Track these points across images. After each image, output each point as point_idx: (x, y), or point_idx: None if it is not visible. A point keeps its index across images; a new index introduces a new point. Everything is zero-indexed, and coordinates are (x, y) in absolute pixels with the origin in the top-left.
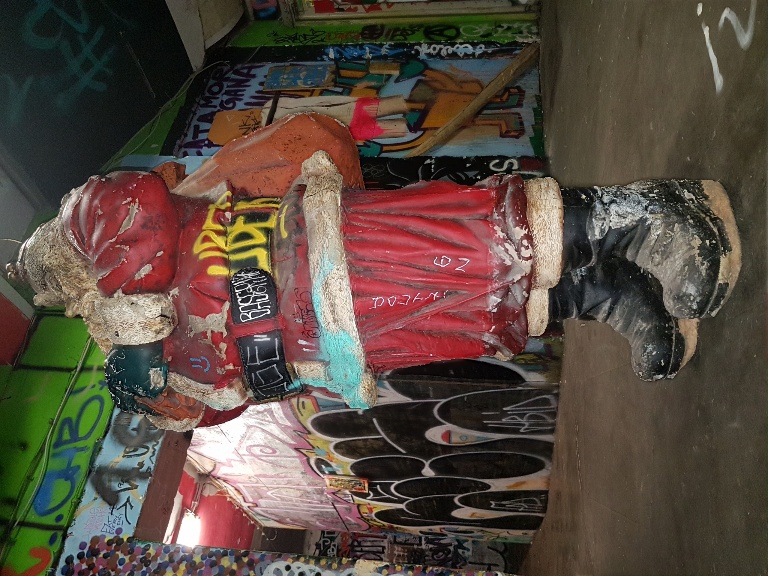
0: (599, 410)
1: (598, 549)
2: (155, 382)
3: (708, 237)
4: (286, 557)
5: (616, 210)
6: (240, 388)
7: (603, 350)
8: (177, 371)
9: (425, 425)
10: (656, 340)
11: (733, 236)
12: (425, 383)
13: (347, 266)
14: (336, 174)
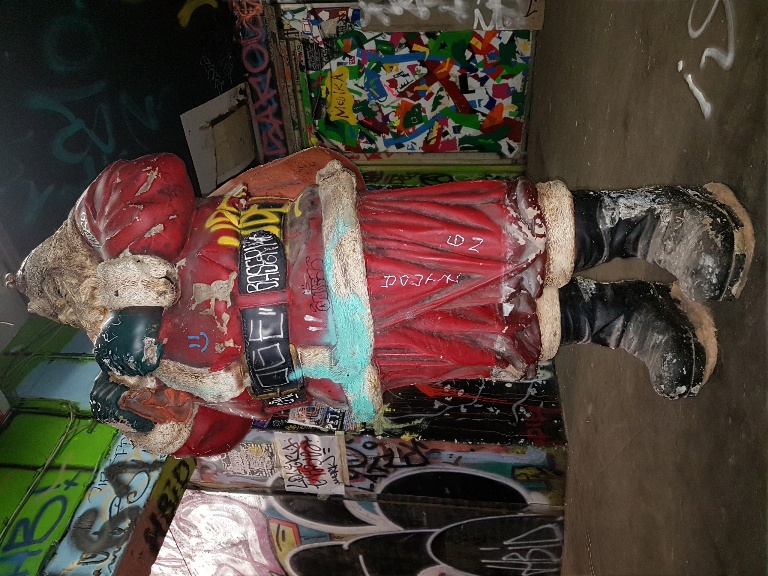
0: (613, 501)
1: None
2: (148, 356)
3: (718, 216)
4: None
5: (624, 203)
6: (237, 374)
7: (613, 432)
8: (171, 357)
9: (417, 565)
10: (675, 348)
11: (743, 215)
12: (419, 506)
13: (361, 237)
14: None
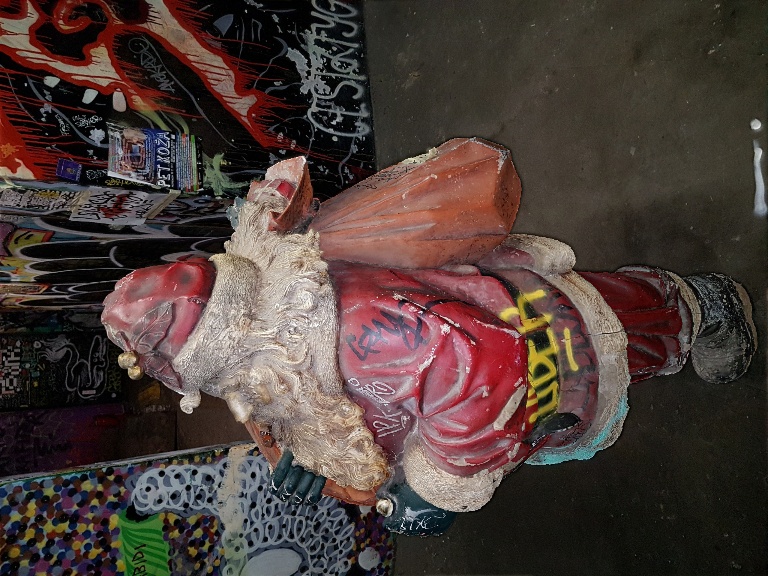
0: None
1: None
2: None
3: None
4: (157, 464)
5: (711, 314)
6: None
7: None
8: None
9: (171, 251)
10: None
11: (756, 341)
12: (211, 228)
13: None
14: None
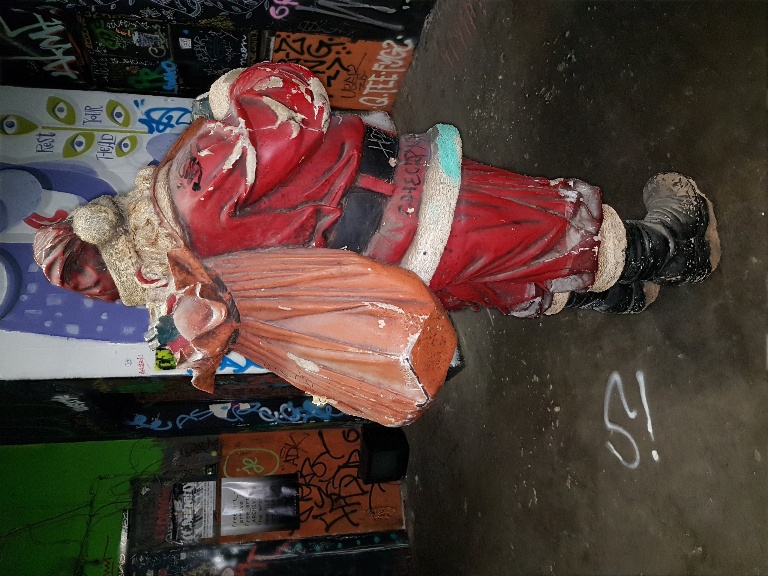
0: None
1: None
2: None
3: None
4: None
5: None
6: None
7: None
8: None
9: None
10: None
11: None
12: None
13: None
14: None
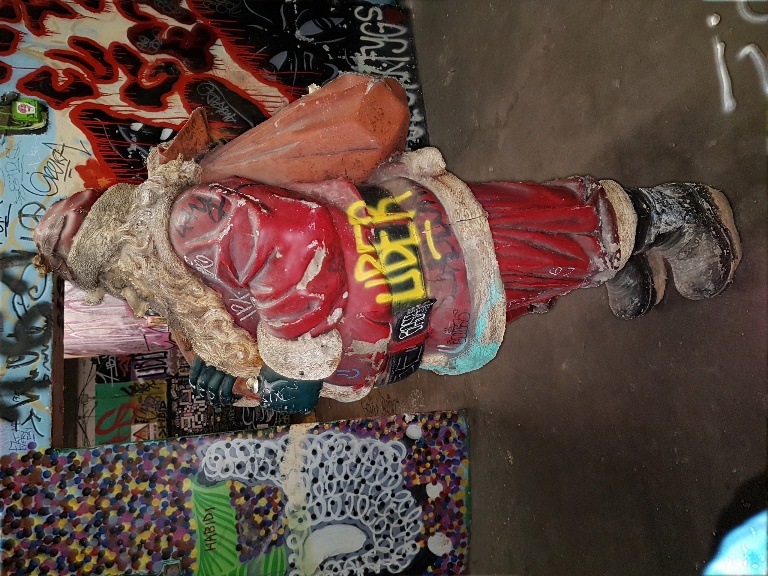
0: None
1: (487, 391)
2: None
3: (725, 248)
4: (224, 437)
5: (666, 219)
6: (372, 384)
7: None
8: None
9: None
10: (641, 295)
11: (739, 247)
12: None
13: None
14: (466, 185)
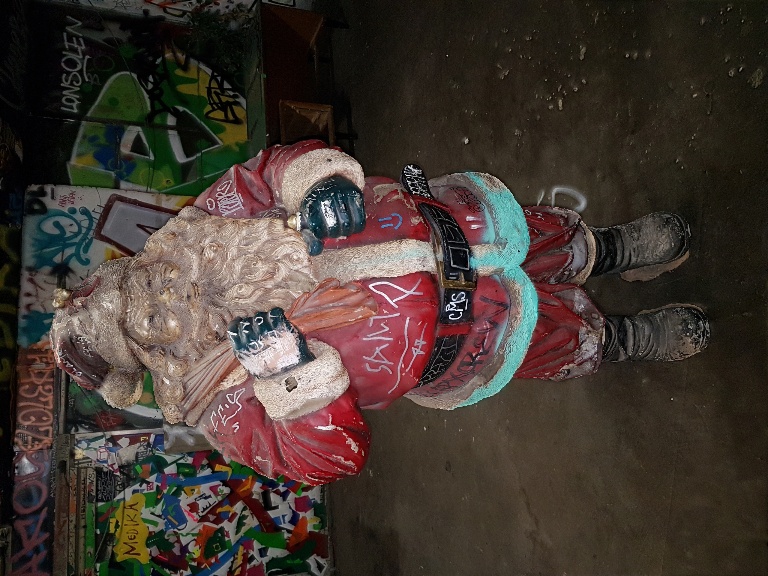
0: None
1: None
2: None
3: None
4: None
5: None
6: None
7: None
8: (359, 245)
9: None
10: (676, 307)
11: None
12: None
13: None
14: None
